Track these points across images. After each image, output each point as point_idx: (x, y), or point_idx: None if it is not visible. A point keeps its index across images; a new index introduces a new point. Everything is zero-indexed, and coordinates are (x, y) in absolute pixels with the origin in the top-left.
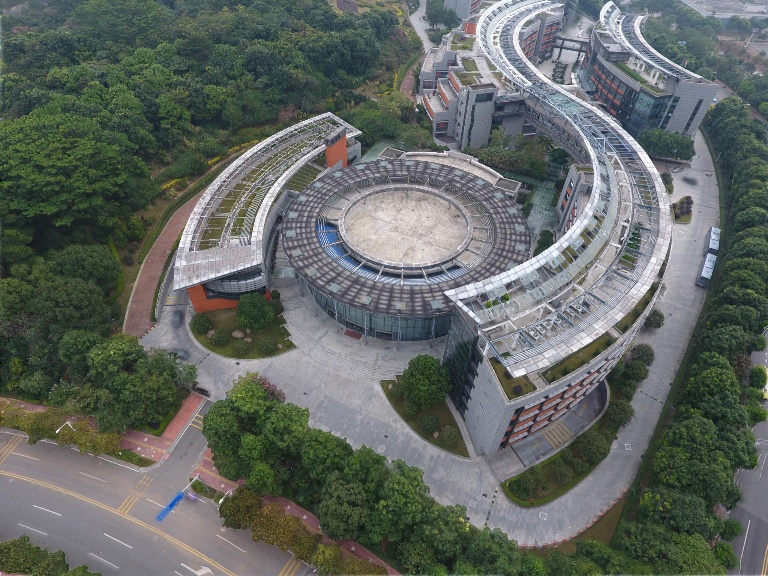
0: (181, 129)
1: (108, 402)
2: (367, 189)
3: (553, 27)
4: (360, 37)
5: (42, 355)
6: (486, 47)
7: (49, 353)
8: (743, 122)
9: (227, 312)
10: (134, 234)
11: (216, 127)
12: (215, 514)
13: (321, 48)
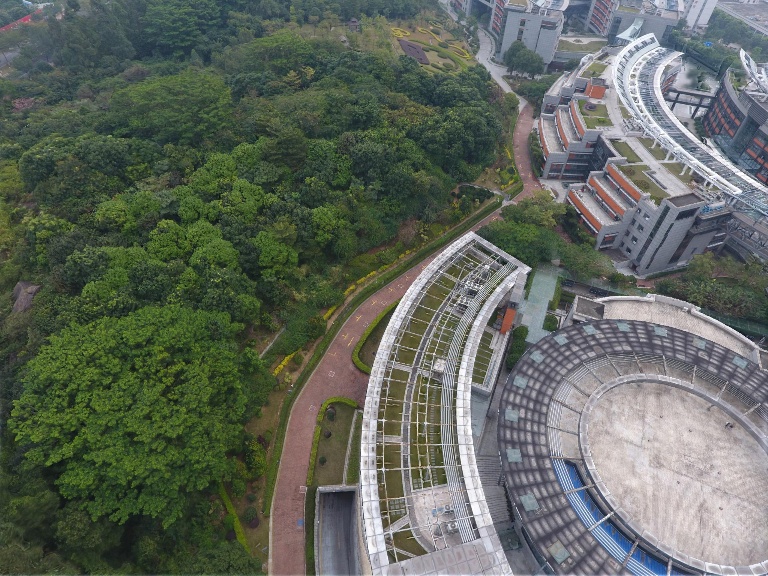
0: (287, 277)
1: None
2: None
3: (670, 79)
4: (480, 115)
5: None
6: (649, 130)
7: None
8: None
9: None
10: (256, 474)
11: (322, 258)
12: None
13: (442, 137)
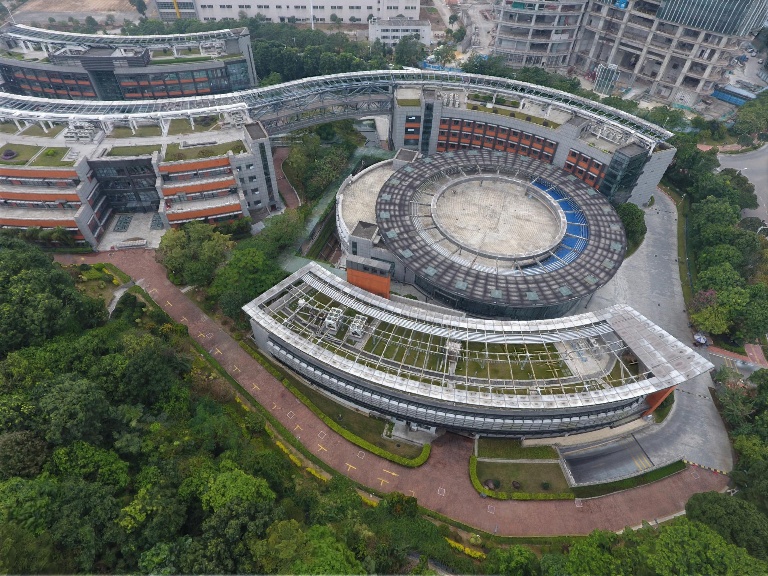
0: None
1: None
2: None
3: None
4: None
5: None
6: None
7: None
8: (263, 46)
9: None
10: None
11: None
12: None
13: None
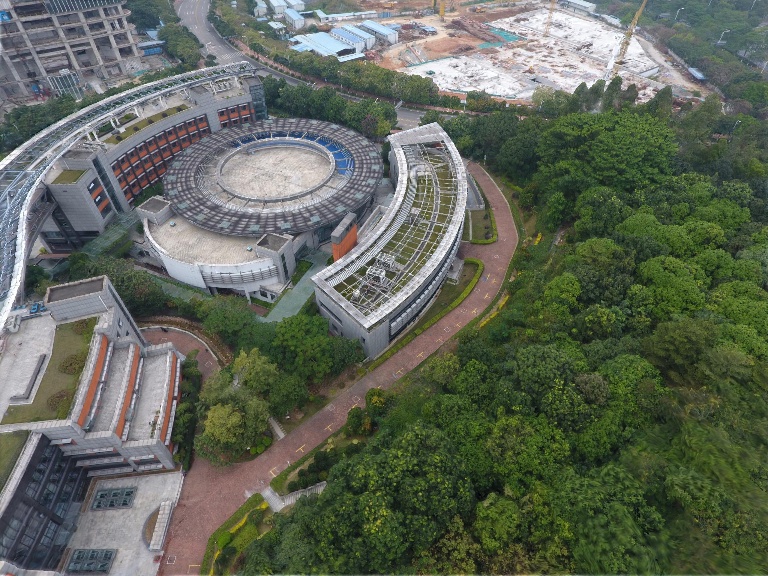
0: None
1: None
2: None
3: None
4: None
5: None
6: None
7: None
8: None
9: None
10: None
11: None
12: None
13: None
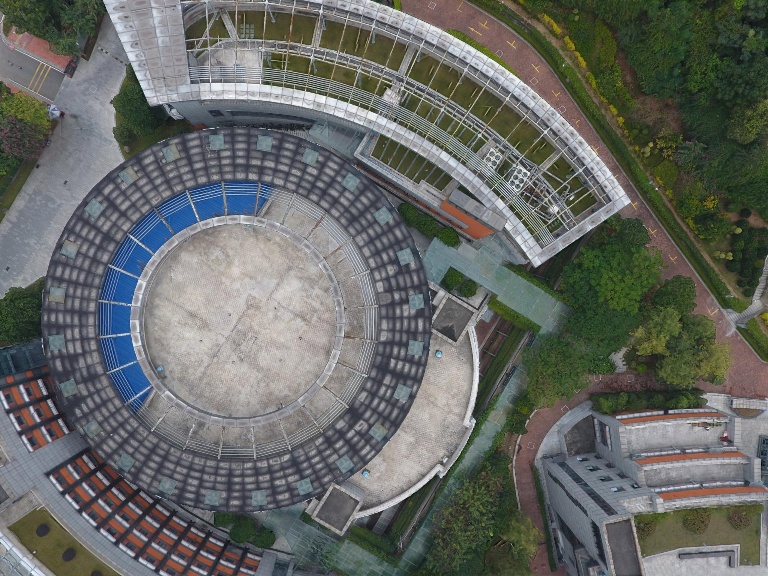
0: None
1: None
2: None
3: None
4: None
5: None
6: None
7: None
8: None
9: None
10: None
11: None
12: None
13: None
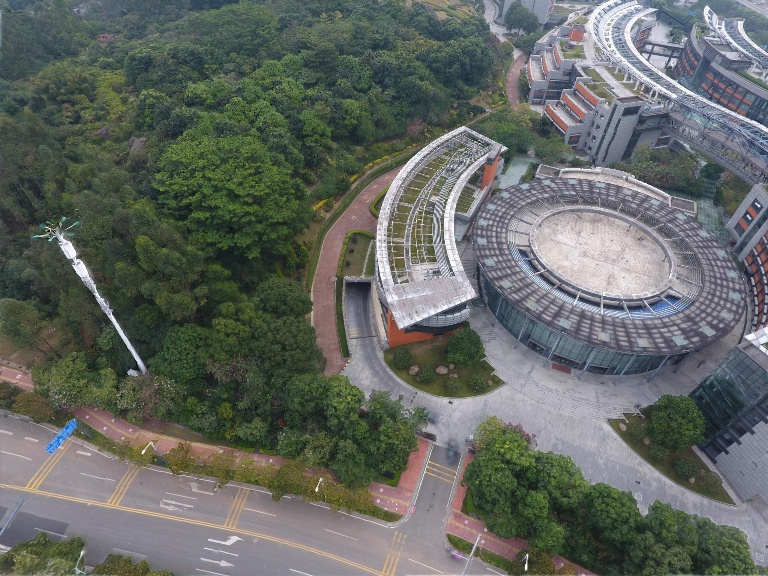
0: (323, 146)
1: (351, 453)
2: (535, 210)
3: (645, 32)
4: (476, 46)
5: (264, 401)
6: None
7: (271, 399)
8: None
9: (421, 345)
10: (302, 261)
11: (348, 143)
12: (487, 574)
13: (444, 58)
